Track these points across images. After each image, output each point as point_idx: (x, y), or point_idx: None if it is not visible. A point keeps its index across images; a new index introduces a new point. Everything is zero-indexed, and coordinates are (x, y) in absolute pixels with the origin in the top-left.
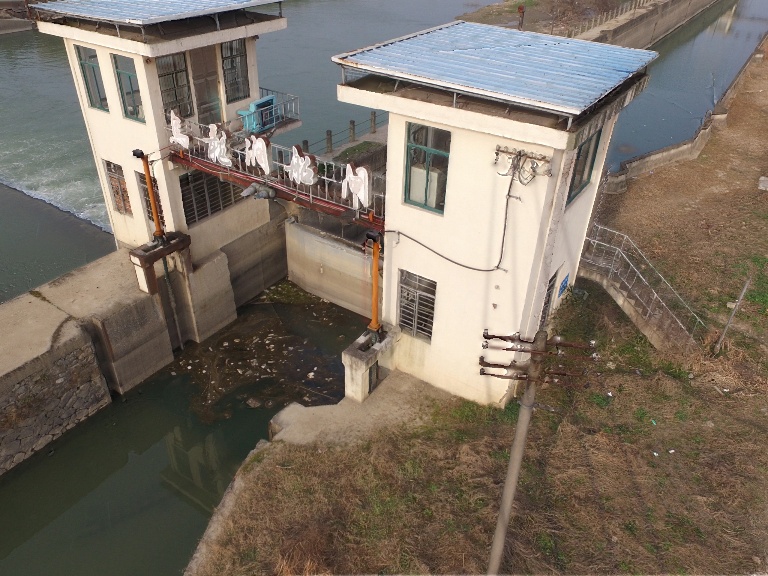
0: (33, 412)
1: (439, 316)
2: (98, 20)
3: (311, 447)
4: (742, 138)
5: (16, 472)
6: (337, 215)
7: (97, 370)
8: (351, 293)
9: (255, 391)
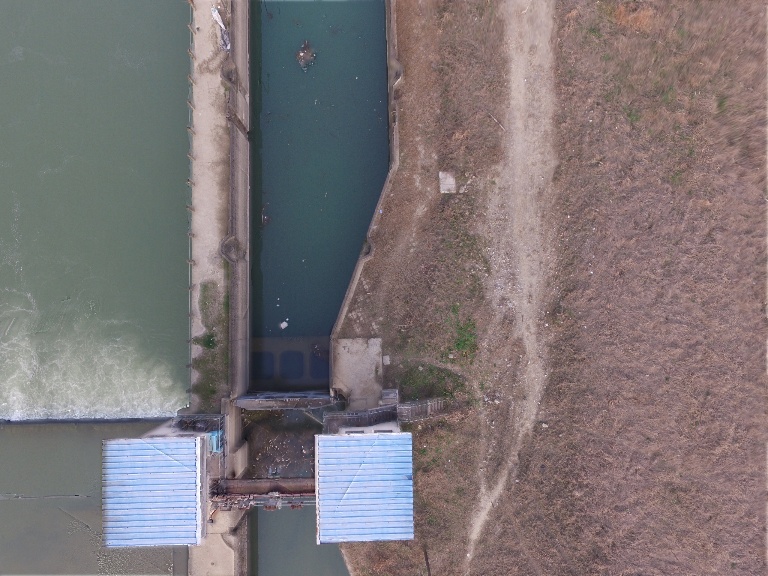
0: None
1: None
2: None
3: None
4: (417, 100)
5: None
6: None
7: (241, 526)
8: None
9: (291, 474)
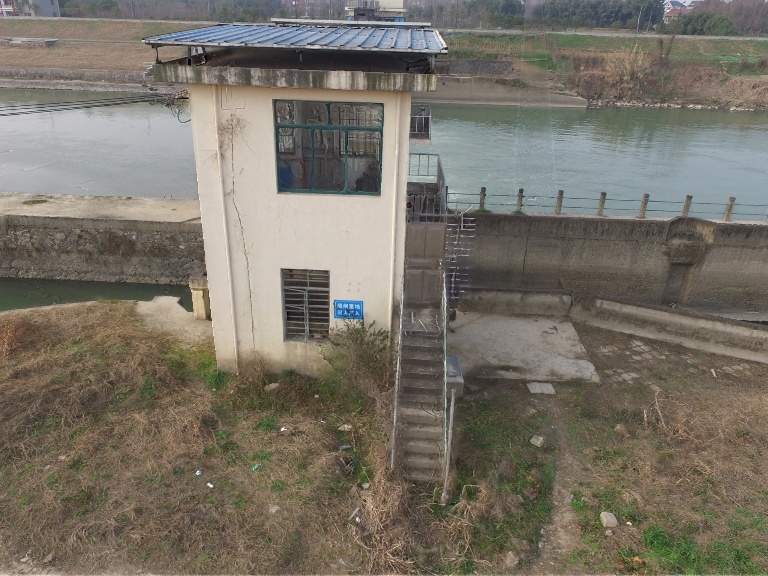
0: (161, 256)
1: None
2: None
3: (134, 314)
4: None
5: (145, 287)
6: None
7: None
8: None
9: None
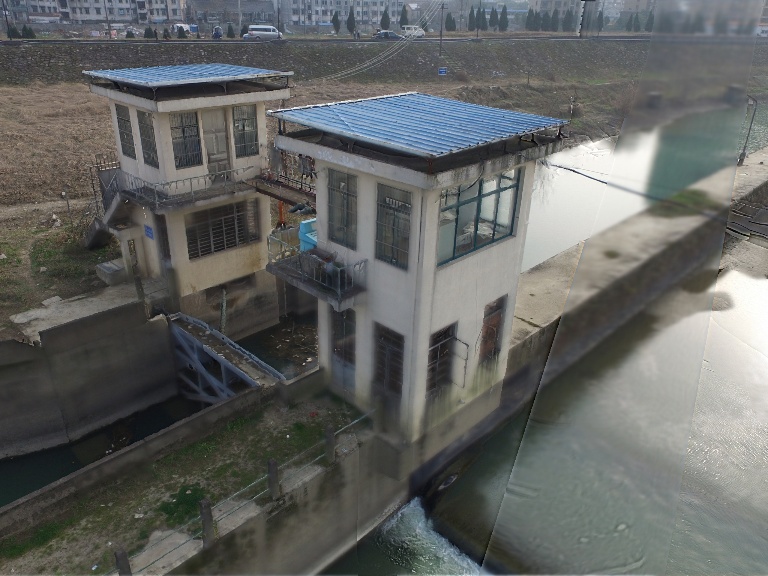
0: None
1: None
2: None
3: None
4: None
5: None
6: None
7: None
8: None
9: None
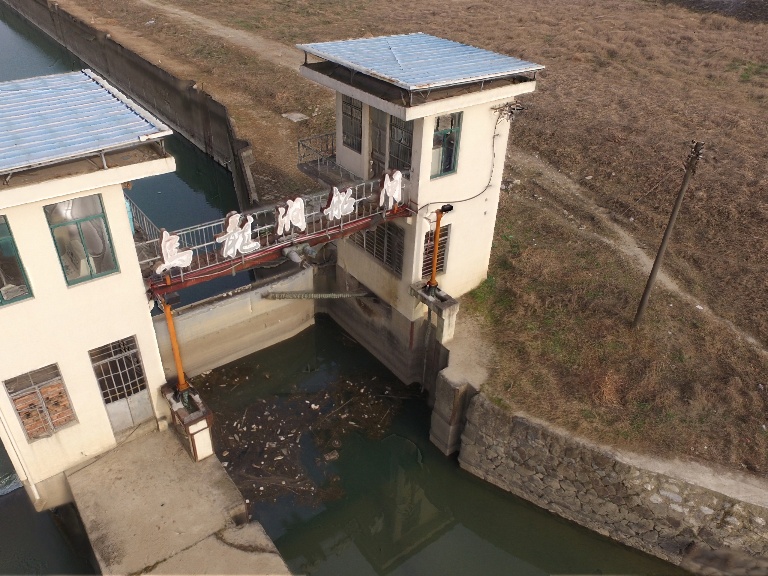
0: None
1: (452, 247)
2: (63, 160)
3: (494, 371)
4: (224, 97)
5: None
6: (369, 226)
7: None
8: (233, 343)
9: (316, 451)
